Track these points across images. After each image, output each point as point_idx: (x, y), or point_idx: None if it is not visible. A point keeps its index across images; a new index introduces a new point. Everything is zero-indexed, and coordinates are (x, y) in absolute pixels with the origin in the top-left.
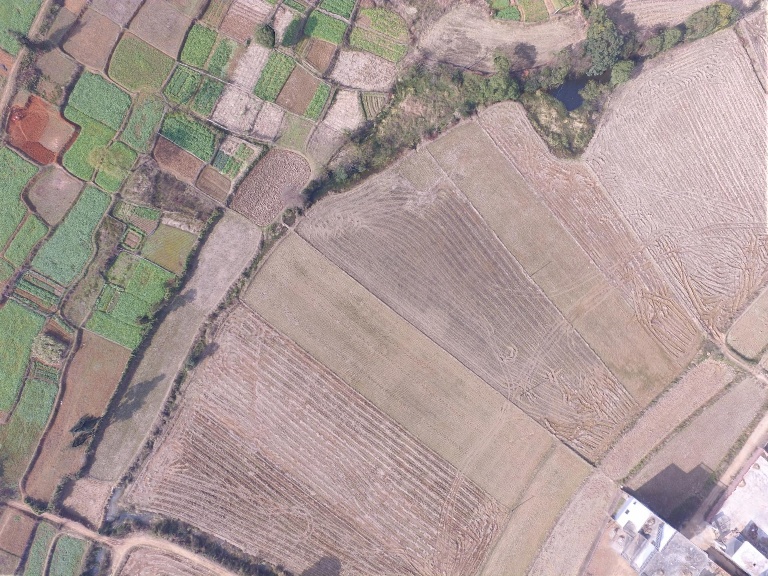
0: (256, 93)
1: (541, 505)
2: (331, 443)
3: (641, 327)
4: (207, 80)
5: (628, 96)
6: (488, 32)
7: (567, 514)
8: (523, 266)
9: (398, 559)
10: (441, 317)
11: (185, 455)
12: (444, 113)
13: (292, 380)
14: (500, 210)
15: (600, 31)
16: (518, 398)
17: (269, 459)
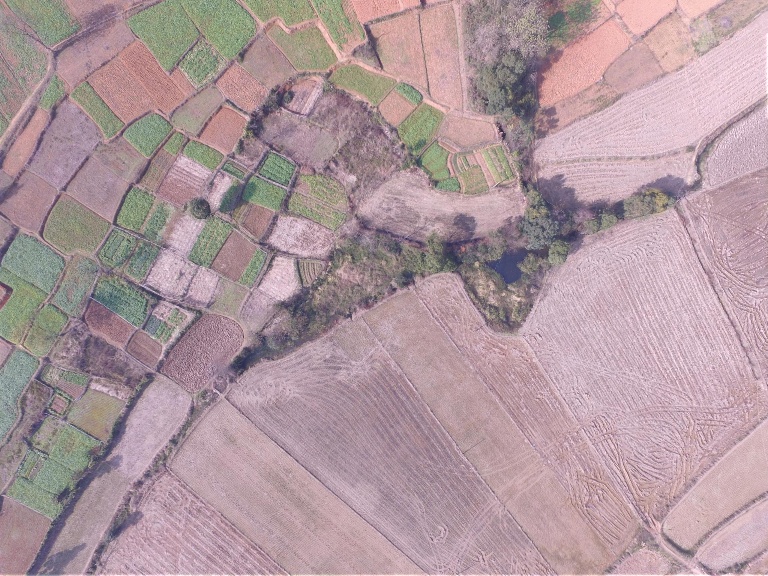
0: (191, 258)
1: None
2: None
3: (575, 511)
4: (142, 244)
5: (567, 271)
6: (428, 202)
7: None
8: (456, 442)
9: None
10: (371, 493)
11: None
12: (381, 282)
13: (216, 554)
14: (435, 383)
15: (535, 216)
16: None
17: None
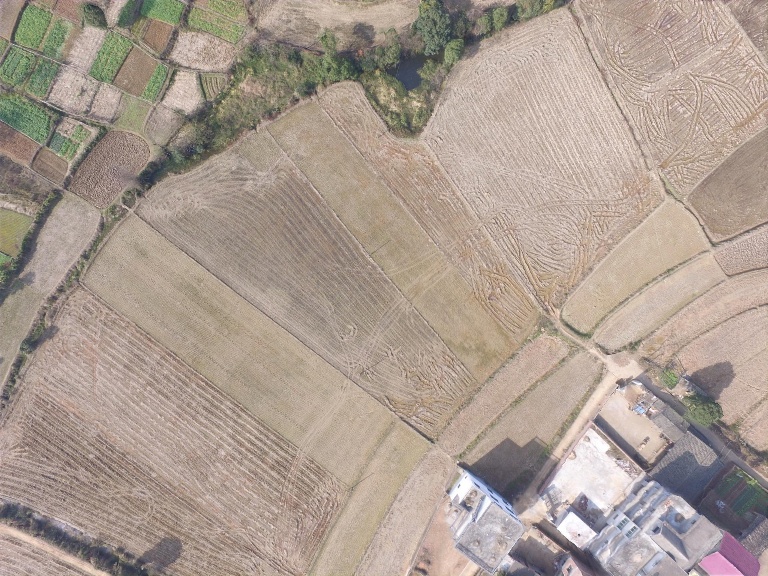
0: (92, 74)
1: (380, 482)
2: (172, 424)
3: (479, 304)
4: (41, 61)
5: (466, 75)
6: (327, 12)
7: (405, 490)
8: (363, 245)
9: (239, 538)
10: (281, 297)
11: (25, 439)
12: (284, 93)
13: (133, 362)
14: (340, 190)
15: (426, 9)
16: (358, 376)
17: (110, 441)
